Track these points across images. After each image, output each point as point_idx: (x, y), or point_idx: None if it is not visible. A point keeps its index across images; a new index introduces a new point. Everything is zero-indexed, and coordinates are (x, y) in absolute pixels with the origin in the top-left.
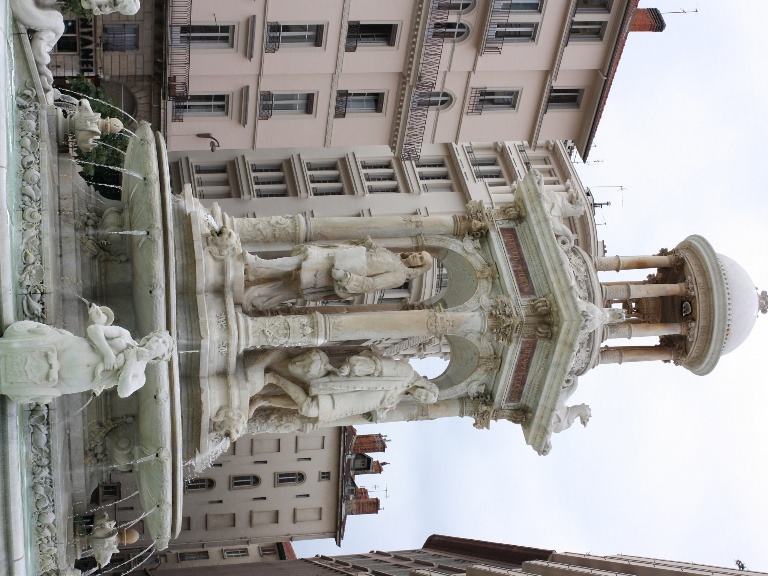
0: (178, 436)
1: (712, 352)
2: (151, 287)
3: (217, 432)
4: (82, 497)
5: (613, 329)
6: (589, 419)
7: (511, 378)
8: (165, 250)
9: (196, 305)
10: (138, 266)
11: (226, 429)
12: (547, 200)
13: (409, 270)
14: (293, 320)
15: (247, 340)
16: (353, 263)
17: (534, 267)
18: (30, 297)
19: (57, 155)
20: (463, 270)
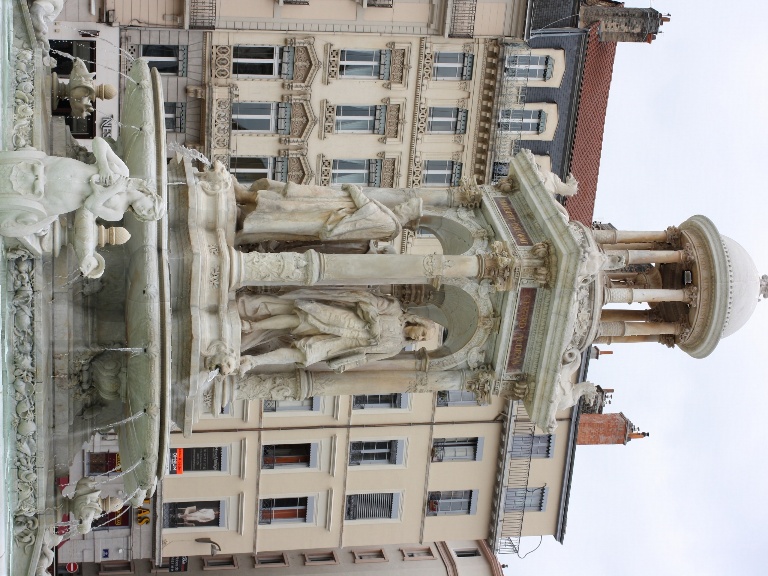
0: None
1: None
2: None
3: None
4: None
5: None
6: None
7: None
8: None
9: (184, 401)
10: None
11: None
12: (583, 273)
13: None
14: (277, 394)
15: None
16: None
17: (534, 342)
18: None
19: None
20: None
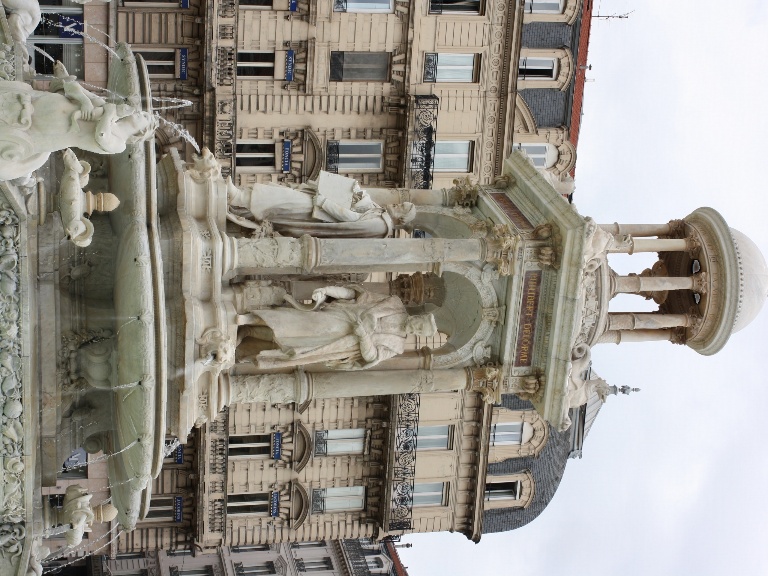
0: None
1: None
2: None
3: None
4: None
5: None
6: None
7: None
8: None
9: None
10: None
11: None
12: None
13: None
14: None
15: None
16: None
17: None
18: None
19: None
20: None
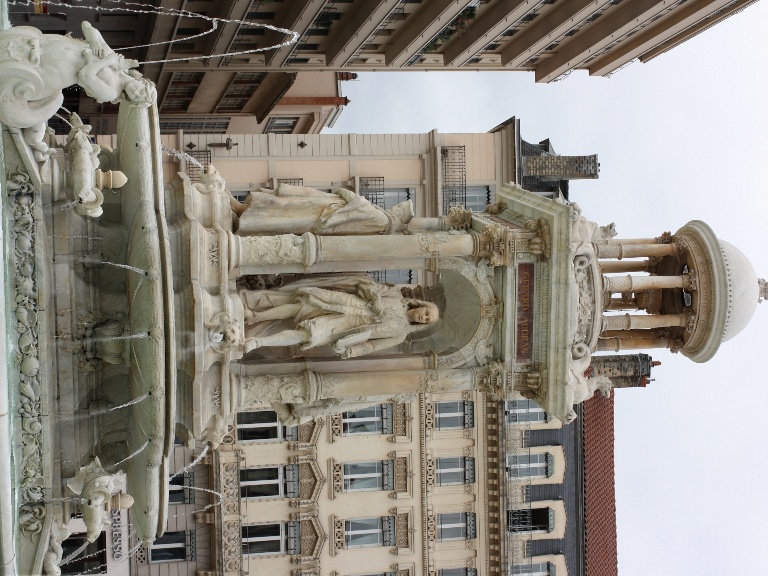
0: (164, 525)
1: None
2: (149, 464)
3: None
4: None
5: (601, 348)
6: None
7: None
8: (166, 437)
9: (191, 393)
10: (137, 426)
11: None
12: (577, 239)
13: (412, 329)
14: (286, 392)
15: (238, 406)
16: (356, 340)
17: (539, 324)
18: (30, 491)
19: (52, 208)
20: (470, 286)
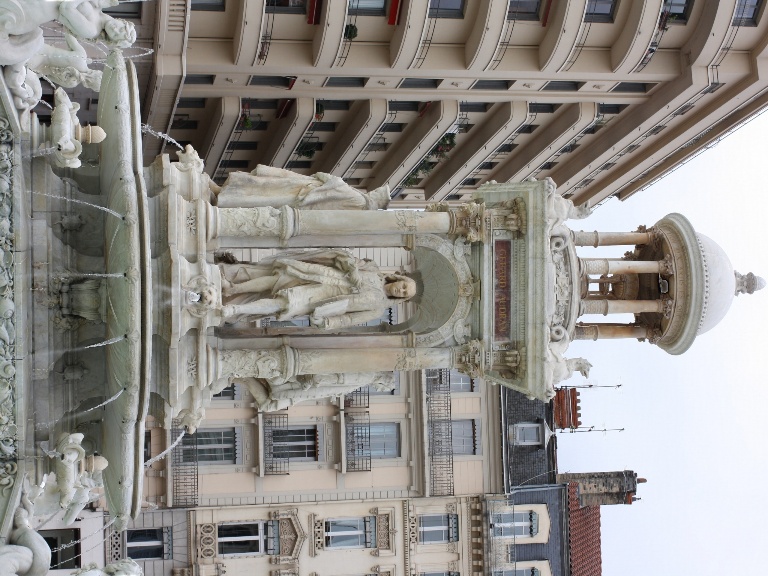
0: (138, 501)
1: (669, 350)
2: (124, 420)
3: None
4: None
5: (579, 336)
6: None
7: None
8: (141, 390)
9: (168, 361)
10: (112, 382)
11: (185, 425)
12: (553, 215)
13: (390, 303)
14: (263, 365)
15: None
16: (333, 310)
17: (517, 302)
18: (2, 443)
19: (30, 164)
20: (448, 267)
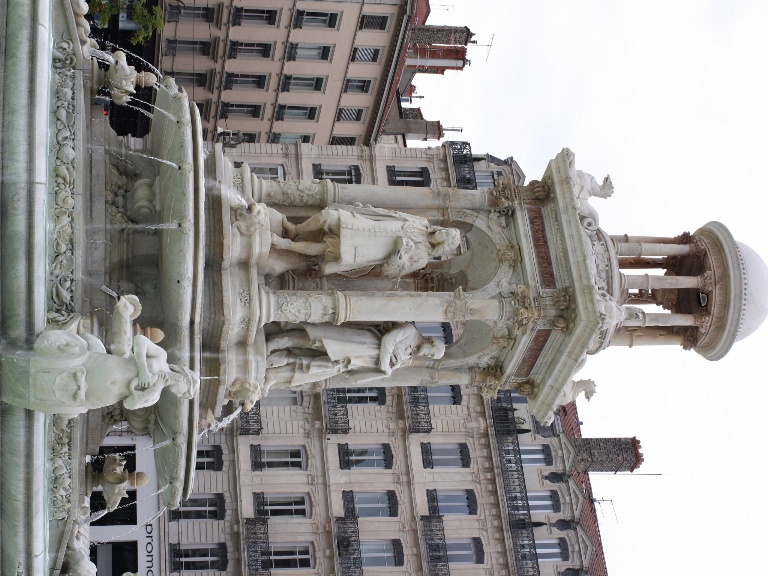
0: None
1: (729, 251)
2: None
3: (239, 222)
4: (101, 301)
5: None
6: (640, 312)
7: (534, 255)
8: None
9: None
10: None
11: None
12: None
13: None
14: None
15: (260, 181)
16: None
17: None
18: None
19: None
20: None
